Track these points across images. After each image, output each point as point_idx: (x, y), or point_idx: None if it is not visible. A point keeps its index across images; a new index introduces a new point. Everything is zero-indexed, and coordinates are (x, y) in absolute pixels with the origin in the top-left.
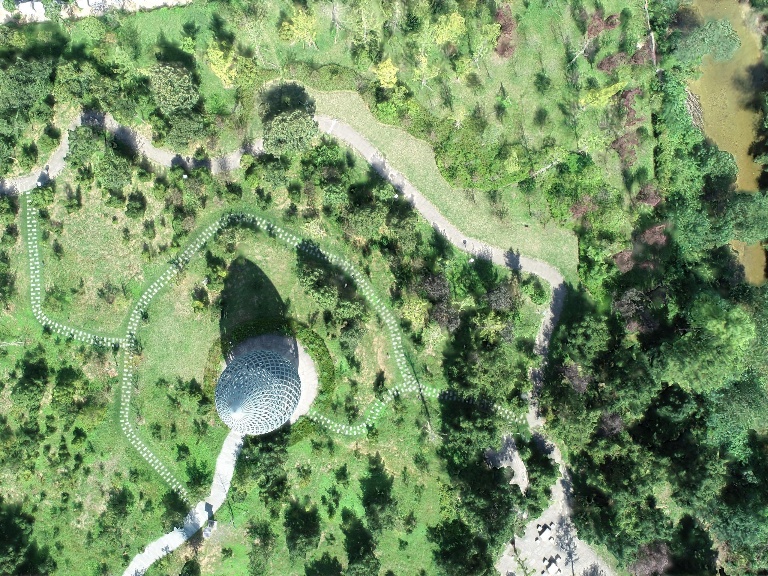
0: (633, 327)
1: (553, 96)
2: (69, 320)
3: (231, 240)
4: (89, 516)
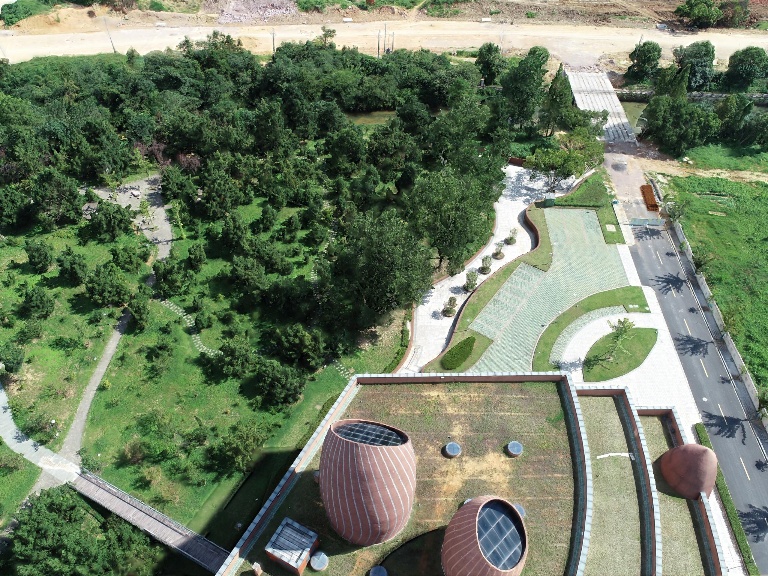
0: (0, 153)
1: None
2: None
3: None
4: None
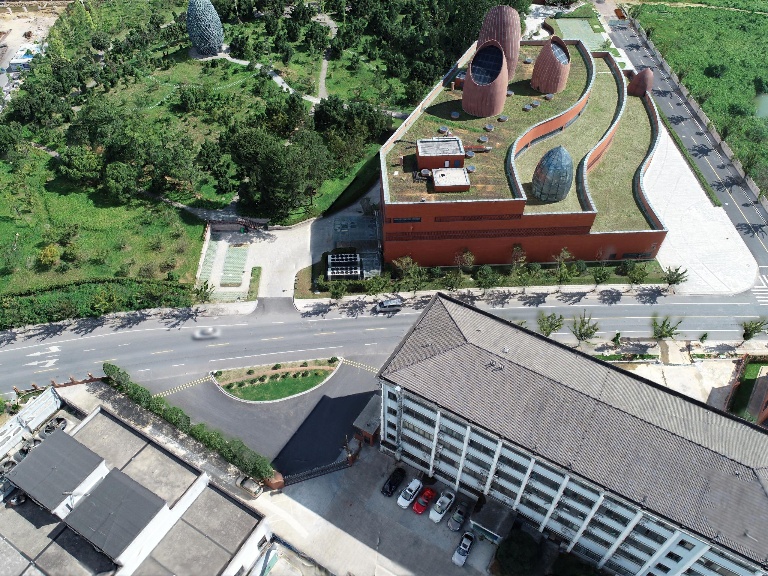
0: None
1: (121, 1)
2: (158, 99)
3: (140, 53)
4: (262, 102)
